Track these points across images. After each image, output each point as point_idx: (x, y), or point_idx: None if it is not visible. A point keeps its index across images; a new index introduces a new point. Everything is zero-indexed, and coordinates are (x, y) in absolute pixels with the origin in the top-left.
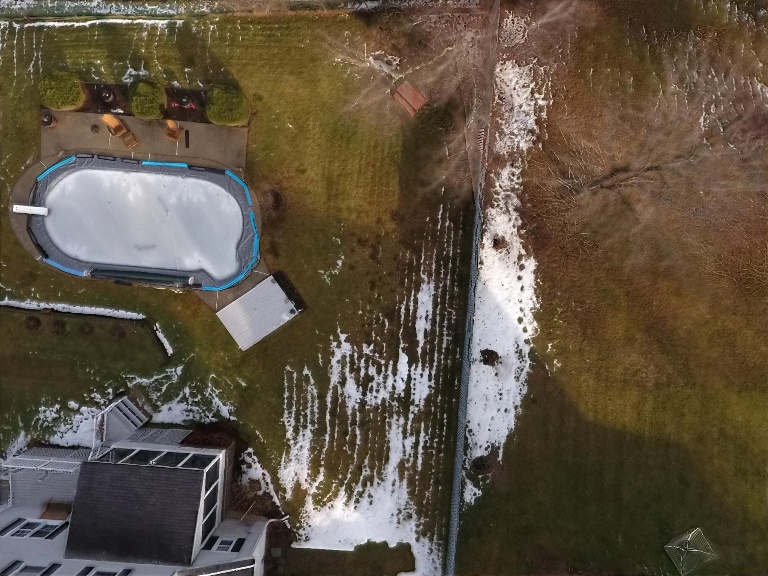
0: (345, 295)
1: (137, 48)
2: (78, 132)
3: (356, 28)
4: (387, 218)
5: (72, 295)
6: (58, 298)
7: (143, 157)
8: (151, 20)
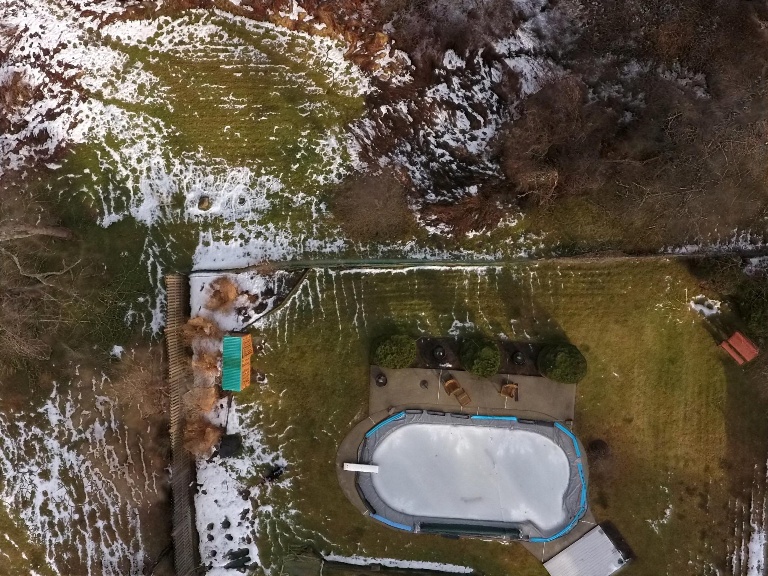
0: (674, 545)
1: (460, 298)
2: (407, 388)
3: (677, 273)
4: (714, 466)
5: (399, 549)
6: (385, 552)
7: (472, 411)
8: (470, 267)
